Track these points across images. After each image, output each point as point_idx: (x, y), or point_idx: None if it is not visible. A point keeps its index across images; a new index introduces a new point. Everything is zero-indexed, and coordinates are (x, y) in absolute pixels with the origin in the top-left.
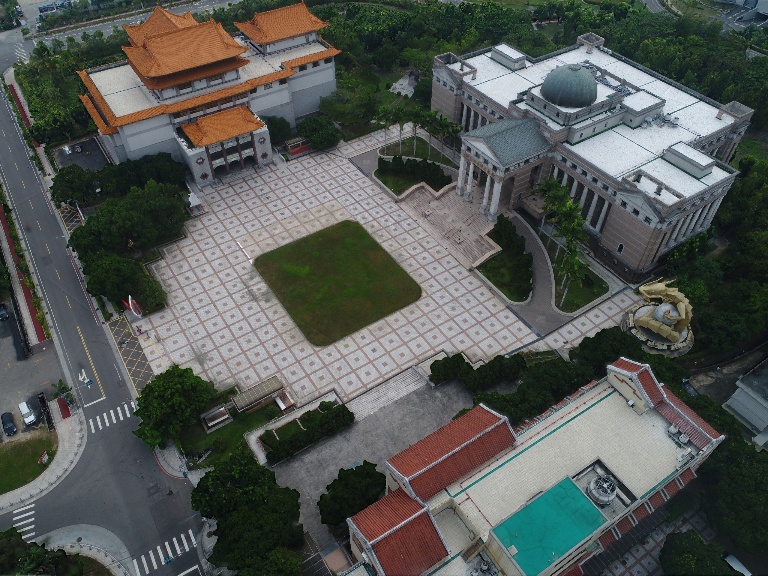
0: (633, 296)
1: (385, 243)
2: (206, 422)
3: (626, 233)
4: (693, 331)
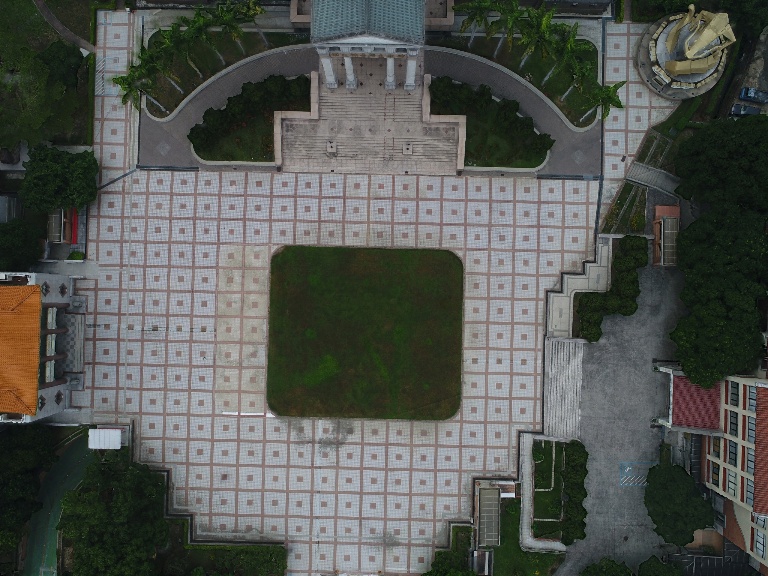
0: (619, 28)
1: (347, 239)
2: (481, 575)
3: None
4: None
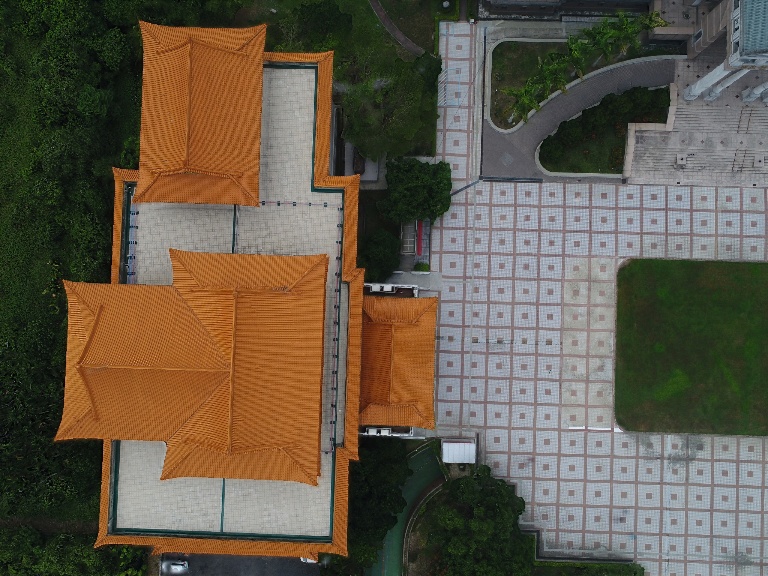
0: None
1: (695, 252)
2: None
3: None
4: None
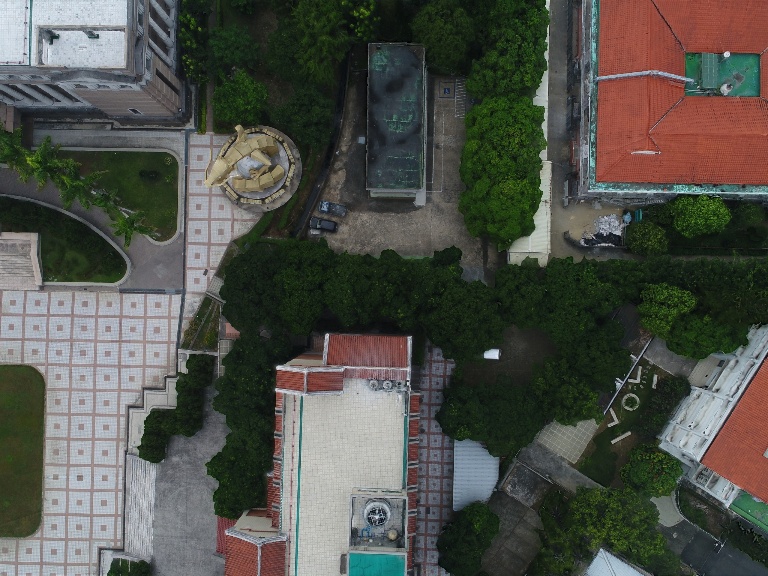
0: (202, 140)
1: None
2: None
3: (120, 102)
4: (285, 131)
